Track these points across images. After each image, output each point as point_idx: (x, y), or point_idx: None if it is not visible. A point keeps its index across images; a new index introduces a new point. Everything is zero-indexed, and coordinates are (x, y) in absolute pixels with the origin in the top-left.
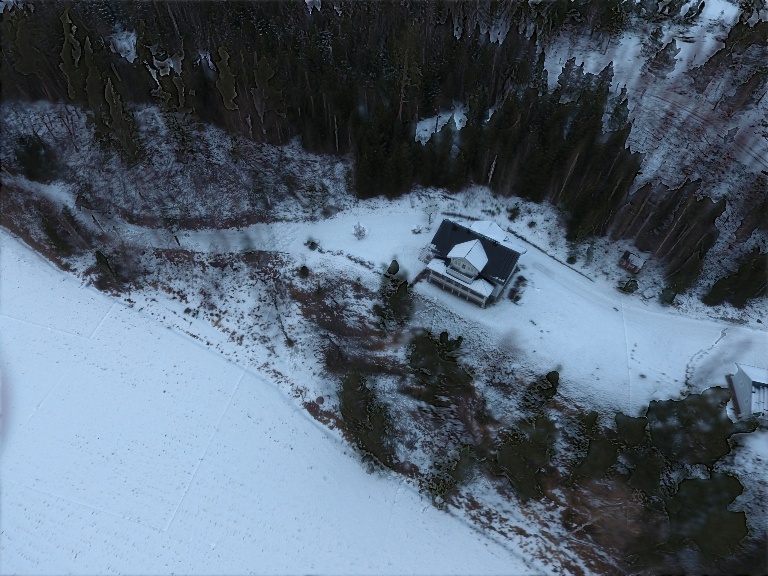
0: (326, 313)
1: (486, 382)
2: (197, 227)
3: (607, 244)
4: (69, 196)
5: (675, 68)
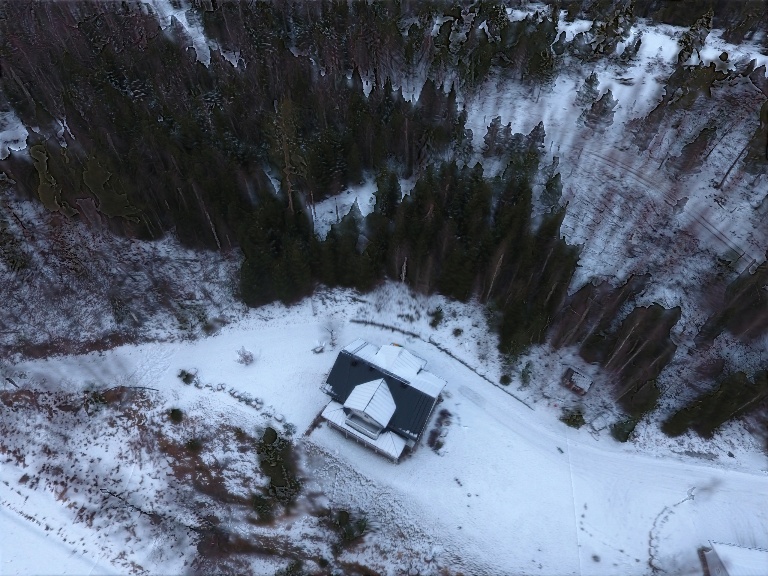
0: (203, 473)
1: (401, 573)
2: (47, 354)
3: (547, 354)
4: None
5: (614, 117)
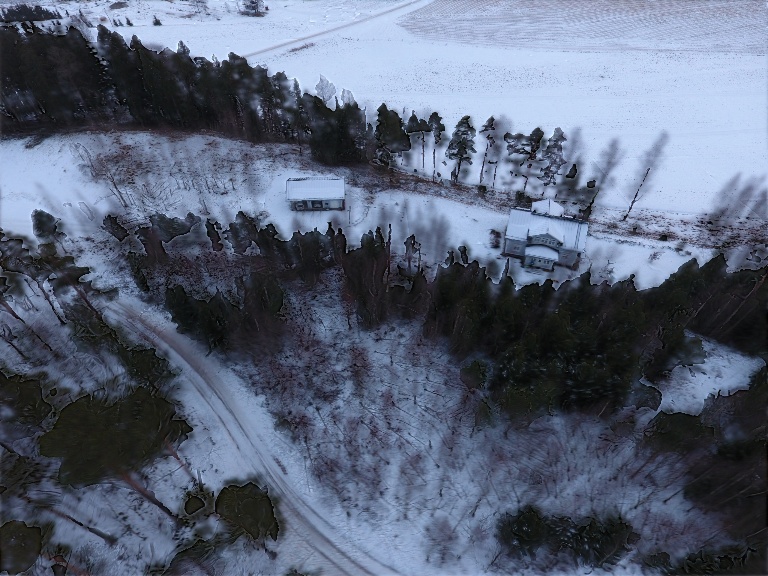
0: None
1: None
2: None
3: None
4: None
5: None
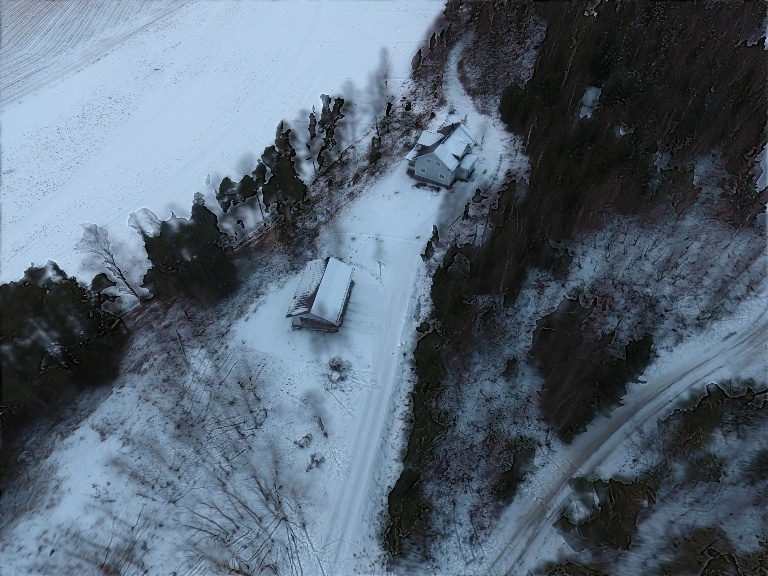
0: None
1: None
2: (462, 81)
3: None
4: (469, 41)
5: None
